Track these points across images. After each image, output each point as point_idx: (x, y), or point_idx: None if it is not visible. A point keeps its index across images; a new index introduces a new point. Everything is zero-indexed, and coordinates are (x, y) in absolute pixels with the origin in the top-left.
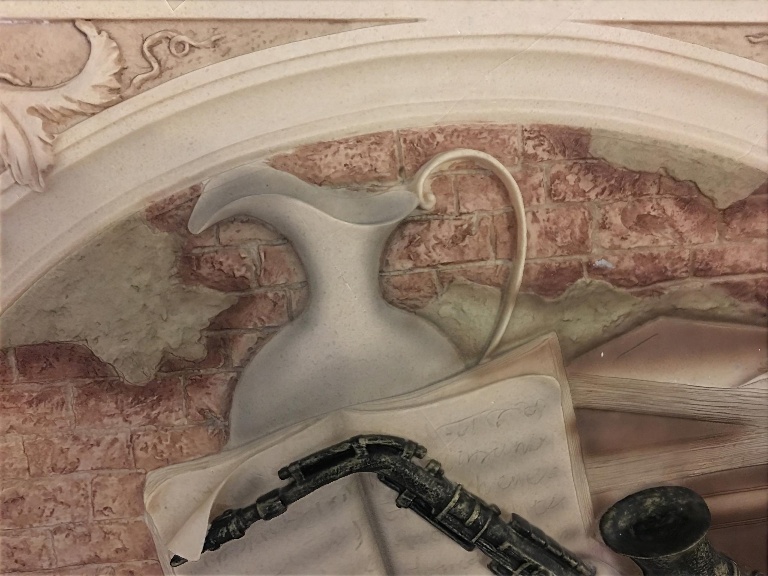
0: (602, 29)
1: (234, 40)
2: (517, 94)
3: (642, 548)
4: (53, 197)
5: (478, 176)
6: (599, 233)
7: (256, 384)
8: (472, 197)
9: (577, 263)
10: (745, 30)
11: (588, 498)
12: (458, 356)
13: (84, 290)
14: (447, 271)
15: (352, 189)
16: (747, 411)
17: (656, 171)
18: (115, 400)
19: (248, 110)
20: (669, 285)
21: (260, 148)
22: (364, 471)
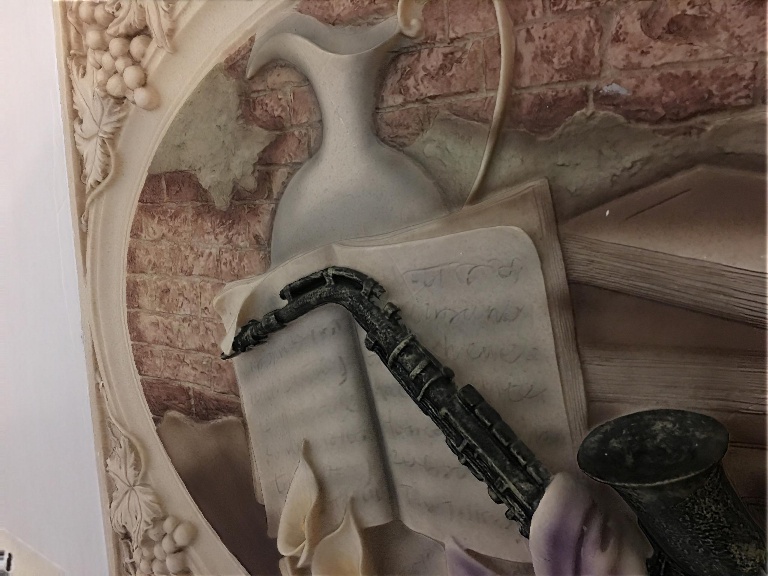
0: None
1: None
2: None
3: (610, 471)
4: (182, 57)
5: None
6: (611, 48)
7: (282, 214)
8: (462, 19)
9: (578, 90)
10: None
11: (581, 401)
12: (443, 202)
13: (193, 129)
14: (433, 105)
15: (356, 24)
16: None
17: None
18: (211, 221)
19: None
20: None
21: None
22: (333, 302)
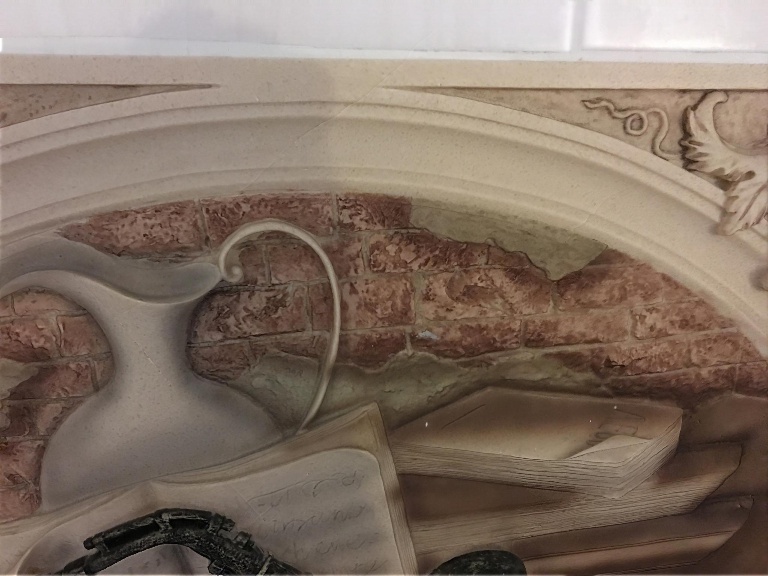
0: (418, 96)
1: (9, 105)
2: (330, 161)
3: None
4: None
5: (291, 246)
6: (423, 304)
7: (62, 454)
8: (284, 268)
9: (399, 335)
10: (581, 94)
11: (413, 560)
12: (275, 426)
13: None
14: (259, 343)
15: (153, 260)
16: (575, 480)
17: (483, 242)
18: None
19: (34, 178)
20: (499, 355)
21: (49, 218)
22: (170, 543)
